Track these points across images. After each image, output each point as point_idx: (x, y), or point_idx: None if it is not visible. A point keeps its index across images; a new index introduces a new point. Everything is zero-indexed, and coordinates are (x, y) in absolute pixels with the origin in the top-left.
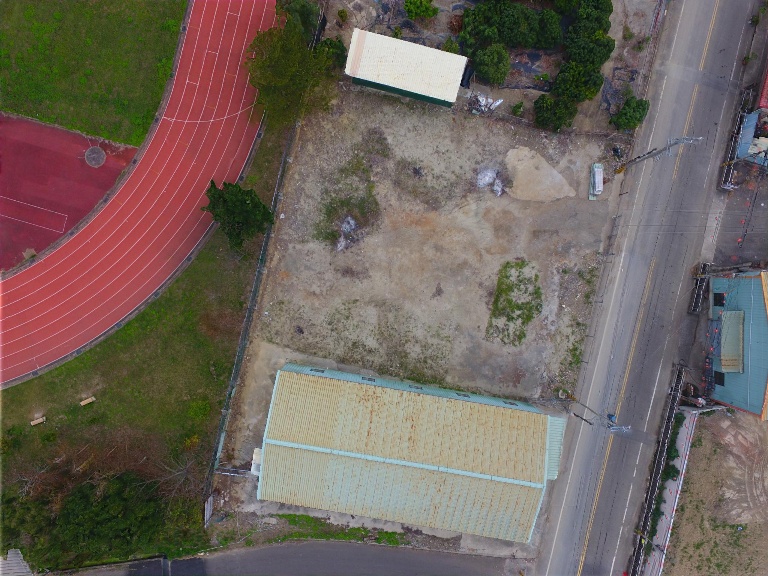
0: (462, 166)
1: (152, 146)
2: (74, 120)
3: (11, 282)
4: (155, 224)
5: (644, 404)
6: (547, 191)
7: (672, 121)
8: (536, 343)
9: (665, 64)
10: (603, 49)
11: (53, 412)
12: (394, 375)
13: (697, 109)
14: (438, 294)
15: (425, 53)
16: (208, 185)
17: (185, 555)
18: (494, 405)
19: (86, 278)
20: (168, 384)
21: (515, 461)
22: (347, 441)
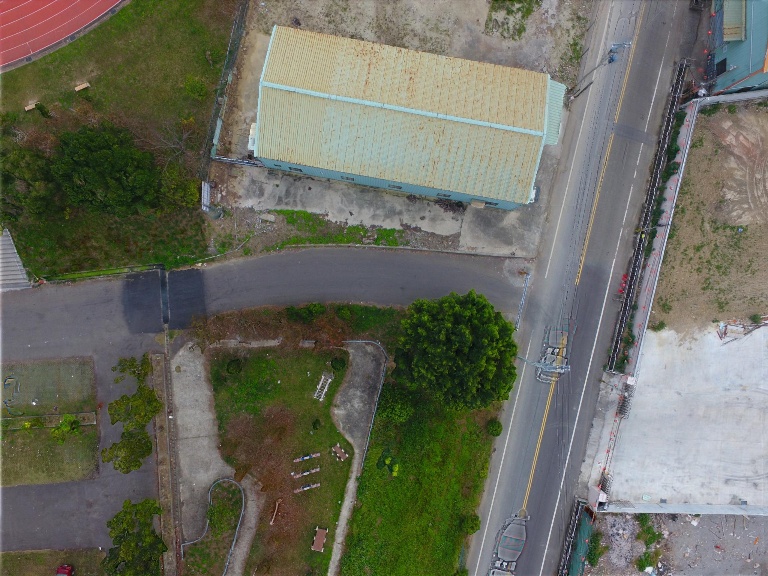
0: None
1: None
2: None
3: None
4: None
5: (645, 103)
6: None
7: None
8: (536, 37)
9: None
10: None
11: (47, 99)
12: None
13: None
14: None
15: None
16: None
17: (183, 265)
18: None
19: None
20: (164, 71)
21: (515, 111)
22: (345, 88)
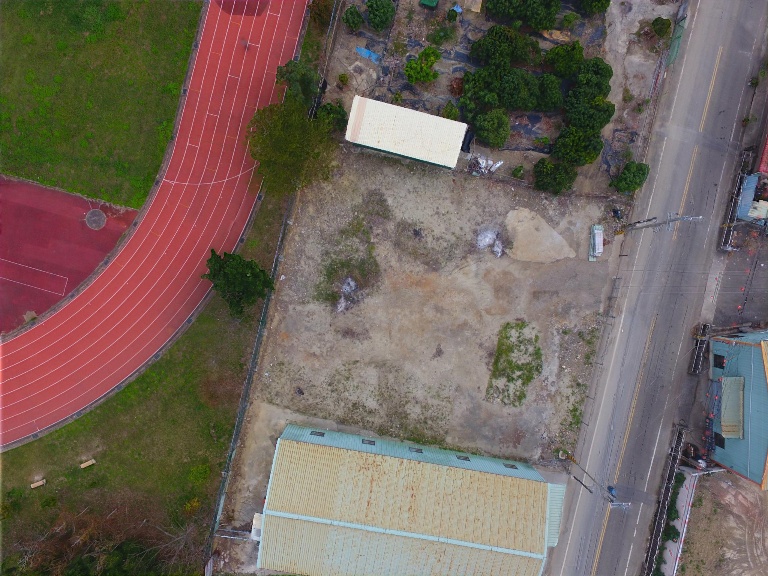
0: (462, 227)
1: (153, 208)
2: (75, 183)
3: (11, 345)
4: (155, 286)
5: (644, 464)
6: (547, 252)
7: (672, 182)
8: (536, 404)
9: (665, 126)
10: (603, 114)
11: (53, 474)
12: (394, 436)
13: (697, 170)
14: (438, 355)
15: (425, 120)
16: (208, 247)
17: None
18: (494, 473)
19: (86, 340)
20: (168, 446)
21: (515, 531)
22: (347, 511)
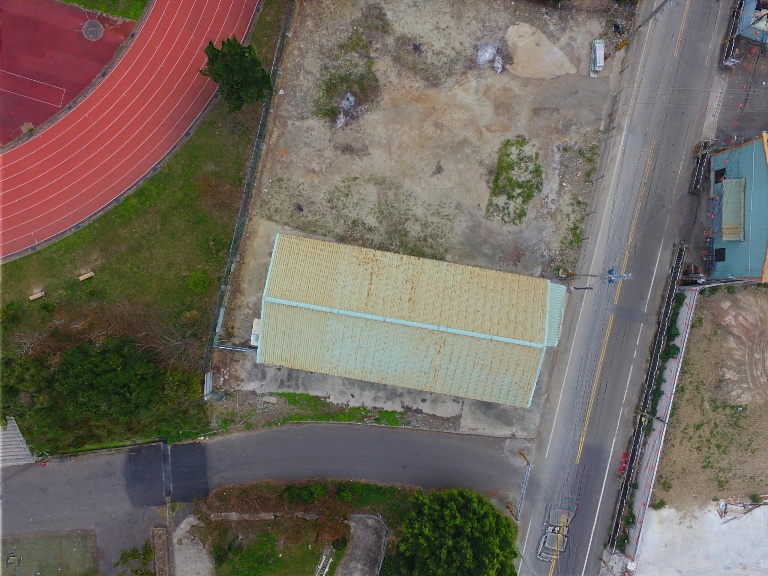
0: (462, 42)
1: (150, 20)
2: None
3: (9, 156)
4: (153, 99)
5: (644, 284)
6: (548, 68)
7: None
8: (536, 222)
9: None
10: None
11: (52, 287)
12: None
13: None
14: (438, 172)
15: None
16: (207, 59)
17: (185, 439)
18: (494, 270)
19: (84, 153)
20: (167, 260)
21: (515, 322)
22: (347, 301)
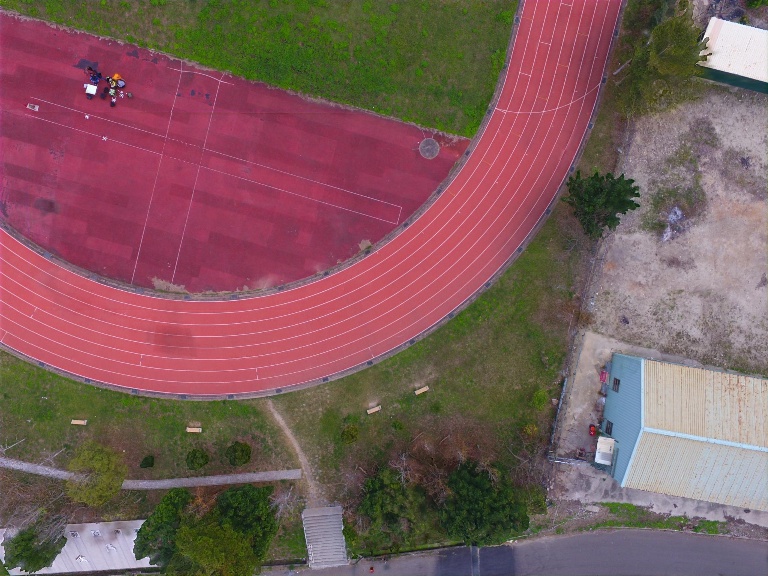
0: None
1: (485, 137)
2: (409, 112)
3: (347, 273)
4: (487, 215)
5: None
6: None
7: None
8: None
9: None
10: None
11: (387, 401)
12: (718, 365)
13: None
14: (763, 284)
15: None
16: (539, 176)
17: None
18: None
19: (420, 269)
20: (499, 374)
21: None
22: (721, 430)
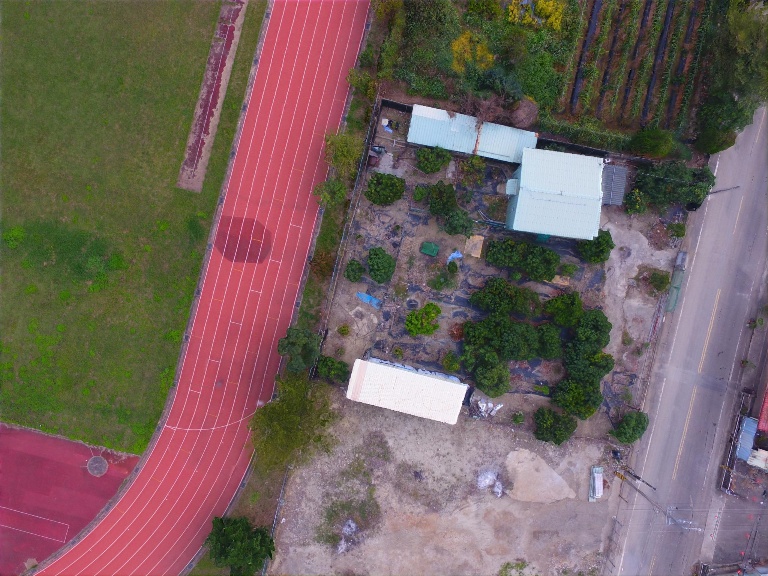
0: (462, 469)
1: (154, 455)
2: (77, 430)
3: None
4: (156, 532)
5: None
6: (547, 493)
7: (671, 423)
8: None
9: (664, 367)
10: (602, 371)
11: None
12: None
13: (696, 411)
14: None
15: (426, 382)
16: (210, 493)
17: None
18: None
19: None
20: None
21: None
22: None
